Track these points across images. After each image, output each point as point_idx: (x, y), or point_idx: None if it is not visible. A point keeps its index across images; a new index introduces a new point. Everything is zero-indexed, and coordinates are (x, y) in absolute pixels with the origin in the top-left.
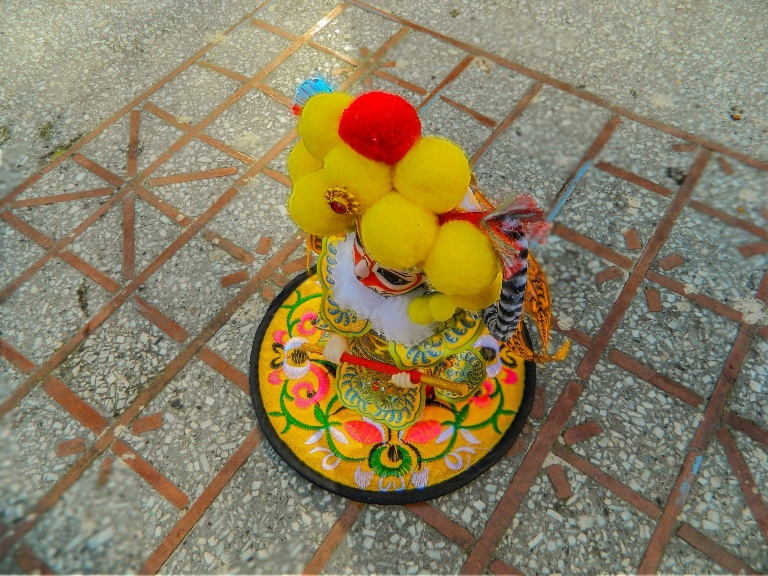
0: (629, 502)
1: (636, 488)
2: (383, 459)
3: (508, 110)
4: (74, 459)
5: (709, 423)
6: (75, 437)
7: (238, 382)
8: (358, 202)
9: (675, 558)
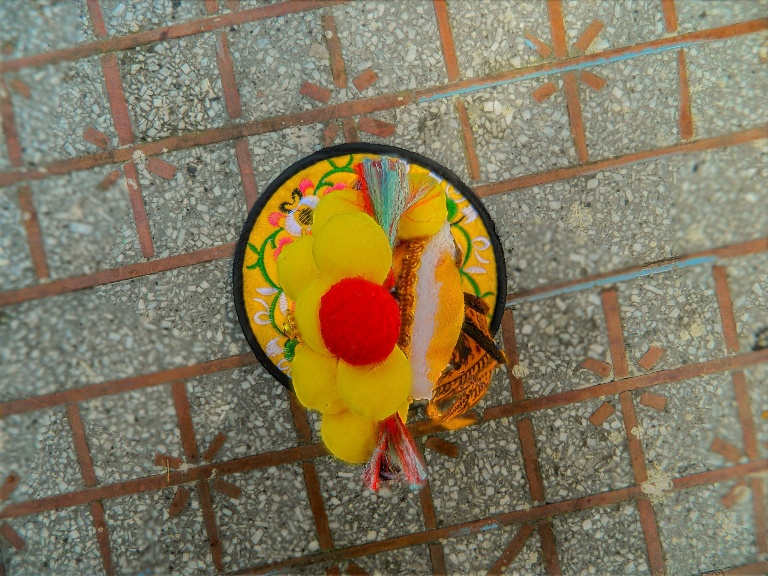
0: (423, 507)
1: (436, 505)
2: (298, 348)
3: (720, 131)
4: (94, 150)
5: (528, 515)
6: (104, 131)
7: (248, 195)
8: (303, 343)
9: (414, 553)
